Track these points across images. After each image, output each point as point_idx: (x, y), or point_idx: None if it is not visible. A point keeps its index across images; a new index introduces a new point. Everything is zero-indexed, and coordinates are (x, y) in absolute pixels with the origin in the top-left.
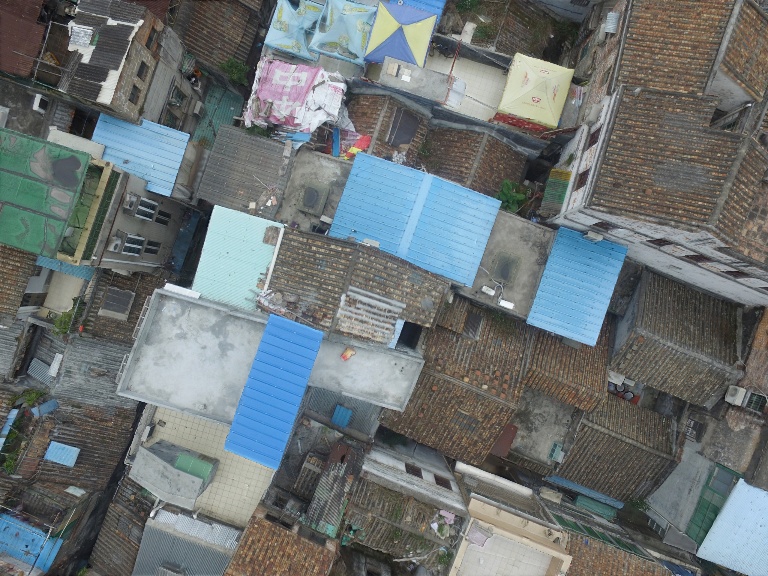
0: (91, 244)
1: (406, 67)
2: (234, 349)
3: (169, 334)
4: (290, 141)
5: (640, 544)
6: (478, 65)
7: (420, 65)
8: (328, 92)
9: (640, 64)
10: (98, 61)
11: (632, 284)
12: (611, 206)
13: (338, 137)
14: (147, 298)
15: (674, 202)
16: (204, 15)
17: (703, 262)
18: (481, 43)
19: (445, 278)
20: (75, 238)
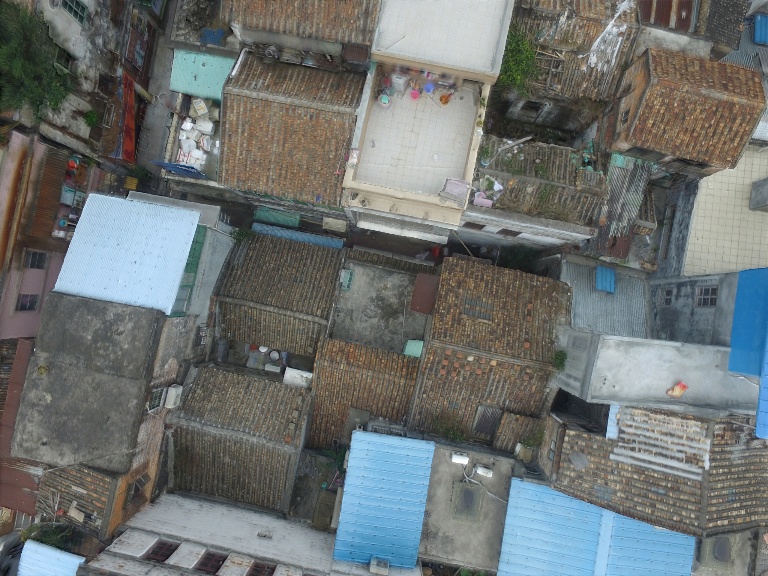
0: None
1: None
2: None
3: None
4: None
5: None
6: None
7: None
8: None
9: None
10: None
11: (297, 492)
12: None
13: None
14: None
15: None
16: None
17: (252, 567)
18: None
19: None
20: None
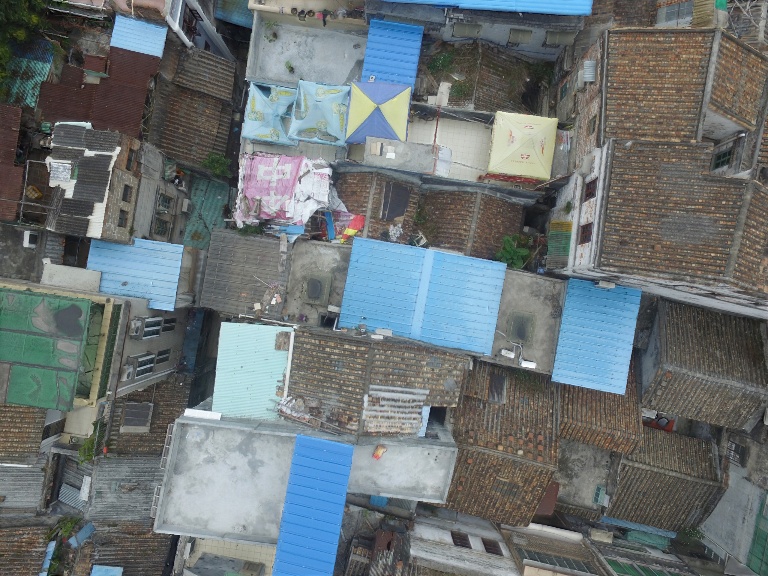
0: (104, 381)
1: (389, 144)
2: (264, 465)
3: (196, 460)
4: (284, 235)
5: (700, 573)
6: (459, 123)
7: (402, 139)
8: (315, 180)
9: (626, 113)
10: (81, 195)
11: (650, 316)
12: (621, 265)
13: (331, 219)
14: (169, 426)
15: (686, 256)
16: (177, 115)
17: (721, 296)
18: (459, 102)
19: (463, 351)
20: (87, 376)
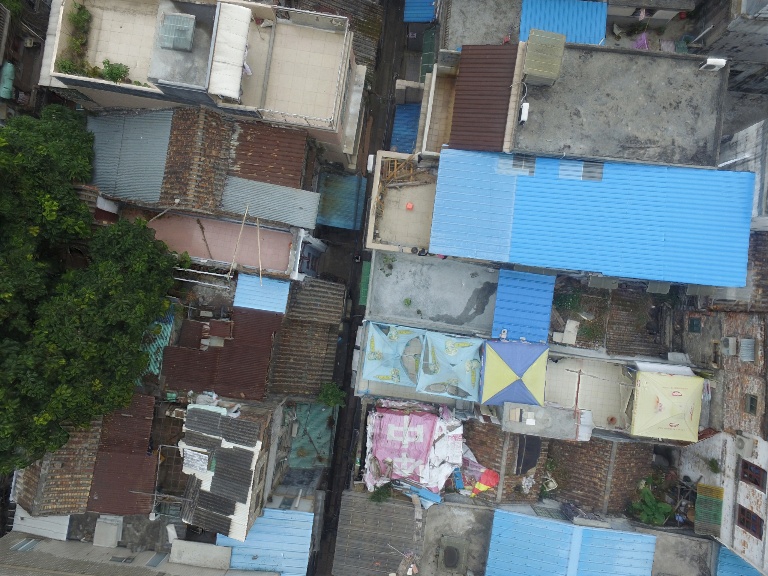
0: None
1: (528, 410)
2: None
3: None
4: (417, 497)
5: None
6: None
7: (542, 403)
8: (449, 443)
9: None
10: (221, 490)
11: None
12: None
13: None
14: None
15: None
16: (288, 345)
17: None
18: (588, 342)
19: None
20: None
